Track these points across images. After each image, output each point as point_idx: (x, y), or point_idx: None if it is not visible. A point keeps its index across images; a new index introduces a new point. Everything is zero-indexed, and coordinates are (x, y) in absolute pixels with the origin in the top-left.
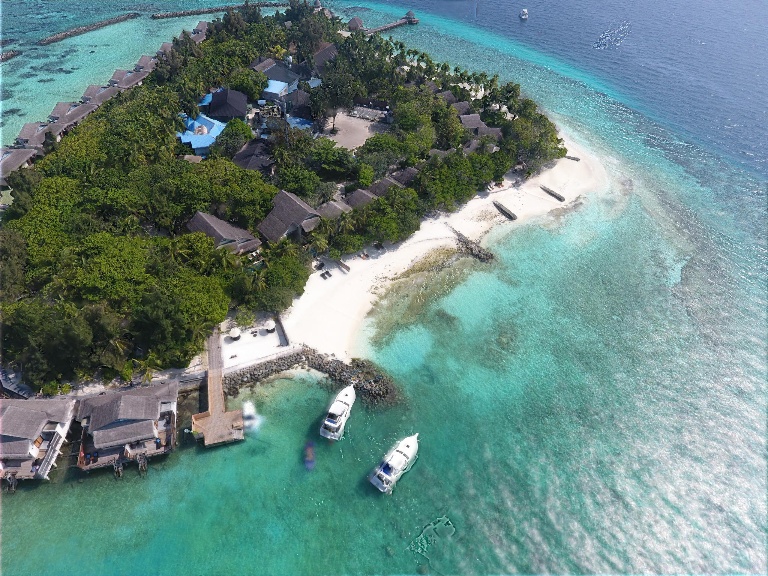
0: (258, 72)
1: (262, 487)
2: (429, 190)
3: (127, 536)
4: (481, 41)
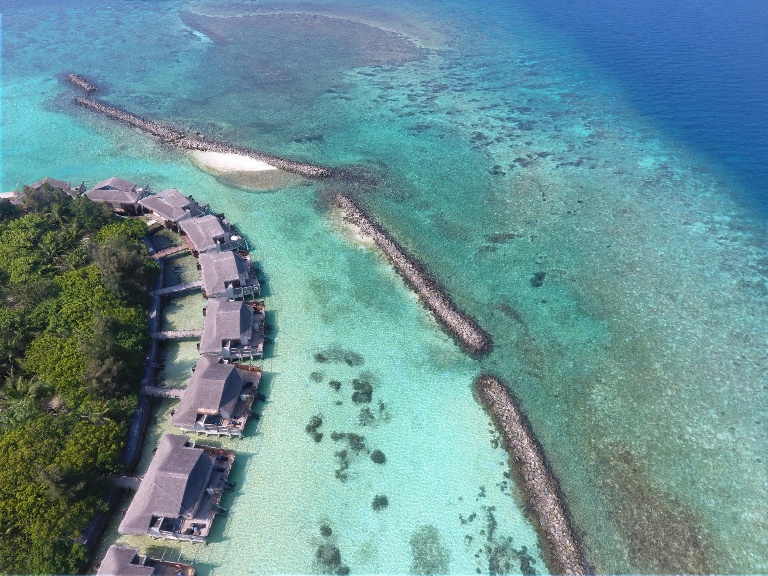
0: None
1: None
2: None
3: (72, 177)
4: None
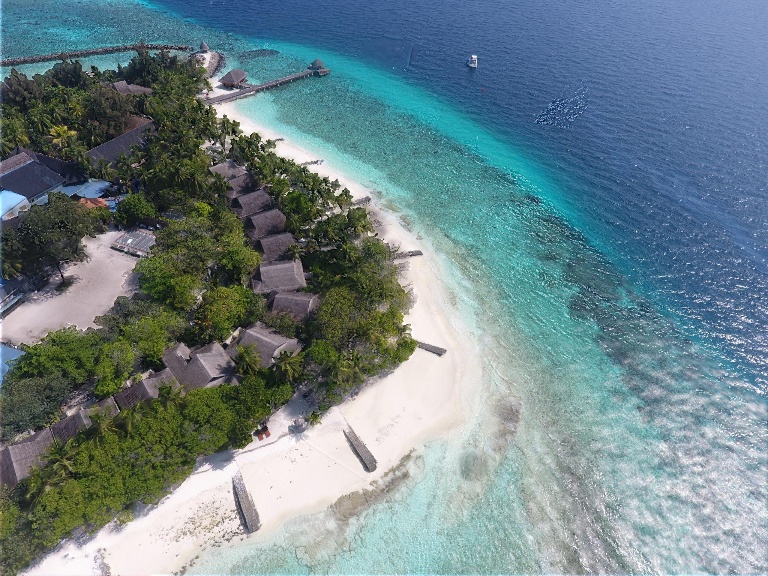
0: None
1: None
2: (31, 519)
3: None
4: (399, 102)
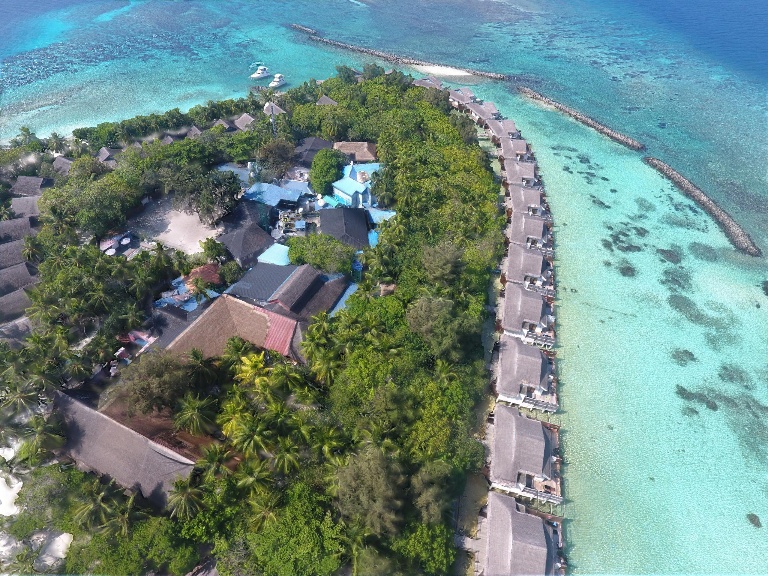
0: (301, 249)
1: (308, 79)
2: None
3: None
4: None
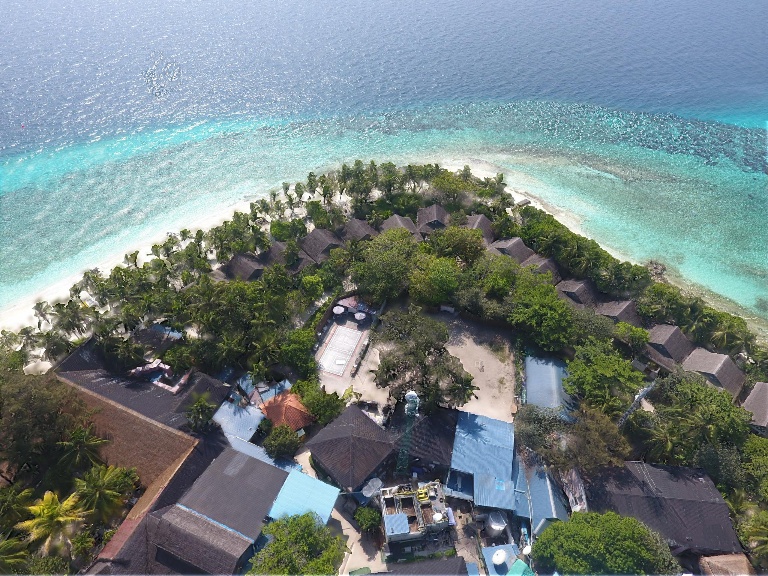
0: None
1: None
2: (650, 271)
3: None
4: (17, 180)
